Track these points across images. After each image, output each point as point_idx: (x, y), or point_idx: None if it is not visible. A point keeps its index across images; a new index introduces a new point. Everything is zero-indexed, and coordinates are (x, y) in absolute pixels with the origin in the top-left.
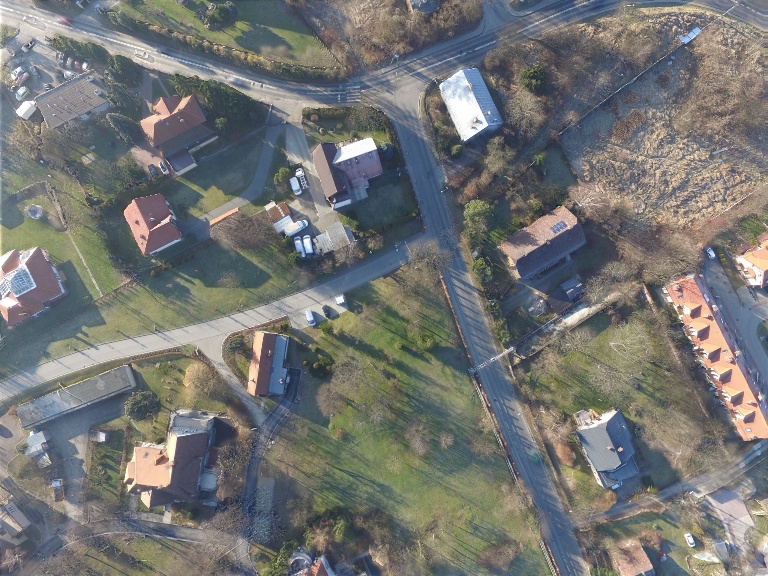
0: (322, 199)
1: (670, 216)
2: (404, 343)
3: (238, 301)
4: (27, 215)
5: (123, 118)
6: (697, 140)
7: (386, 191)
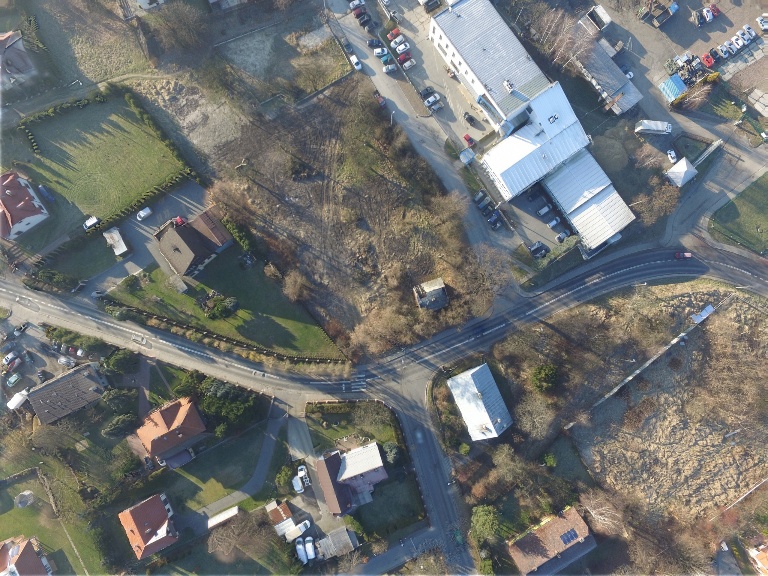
0: None
1: (682, 505)
2: None
3: None
4: (17, 506)
5: (119, 427)
6: (710, 424)
7: (391, 489)
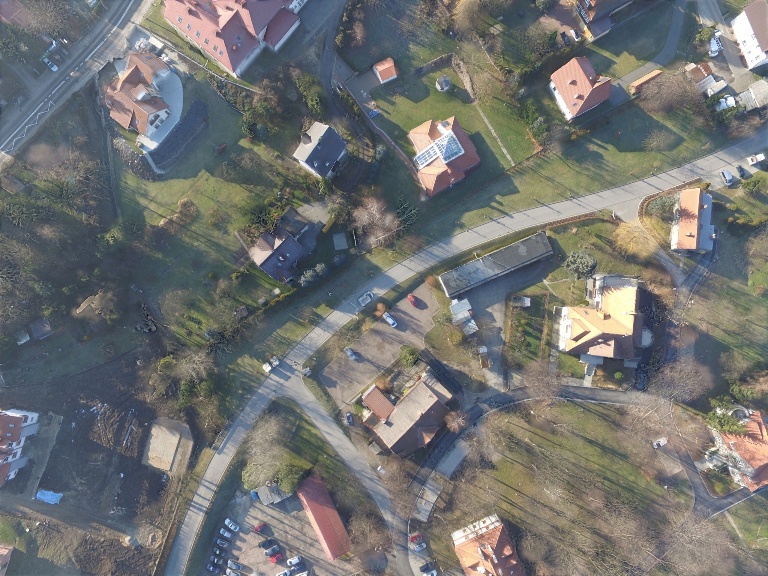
0: (736, 60)
1: None
2: None
3: (653, 164)
4: (441, 86)
5: None
6: None
7: None
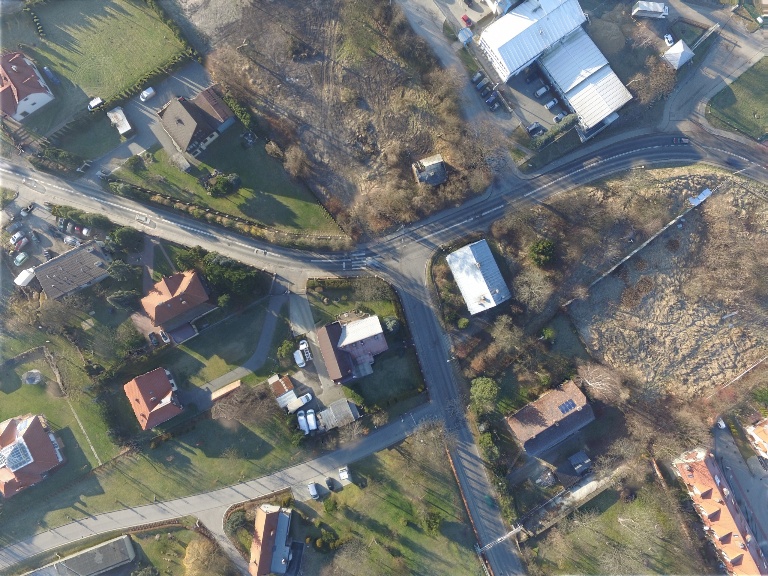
0: (326, 371)
1: (680, 384)
2: (409, 518)
3: (240, 472)
4: (25, 383)
5: (124, 296)
6: (707, 305)
7: (391, 363)
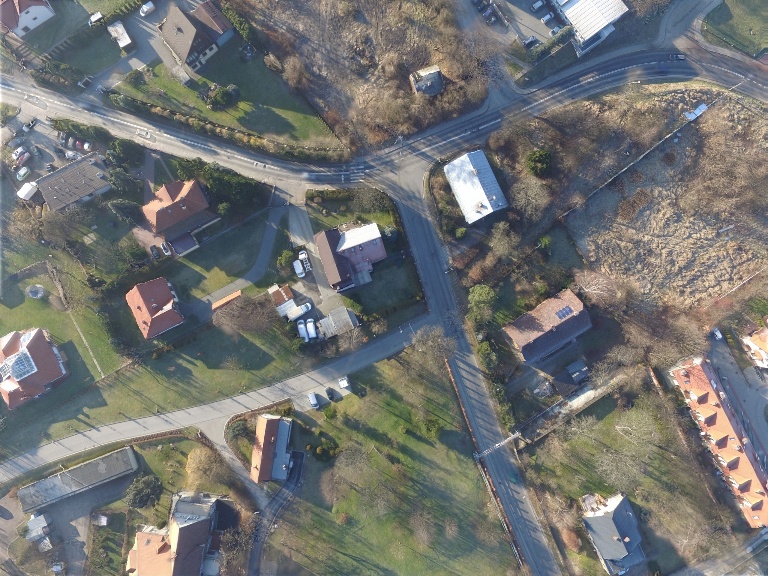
0: (325, 281)
1: (676, 296)
2: (408, 427)
3: (241, 383)
4: (28, 296)
5: (125, 204)
6: (703, 218)
7: (390, 273)
